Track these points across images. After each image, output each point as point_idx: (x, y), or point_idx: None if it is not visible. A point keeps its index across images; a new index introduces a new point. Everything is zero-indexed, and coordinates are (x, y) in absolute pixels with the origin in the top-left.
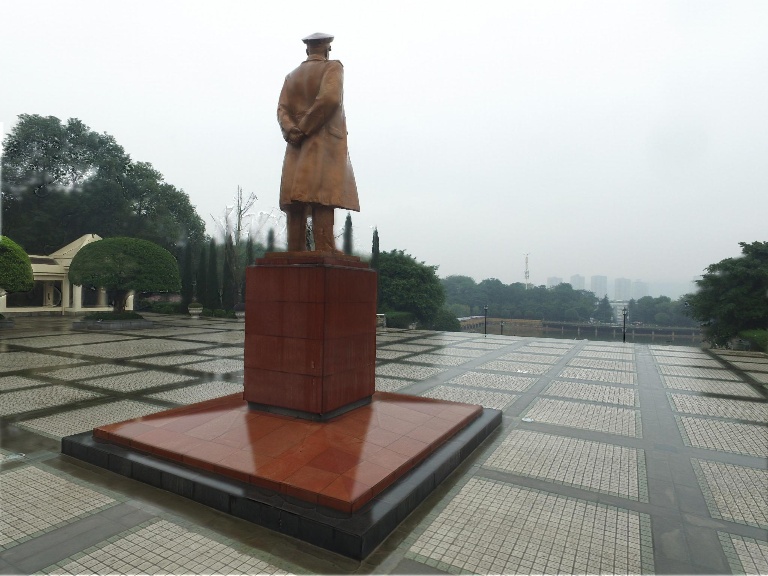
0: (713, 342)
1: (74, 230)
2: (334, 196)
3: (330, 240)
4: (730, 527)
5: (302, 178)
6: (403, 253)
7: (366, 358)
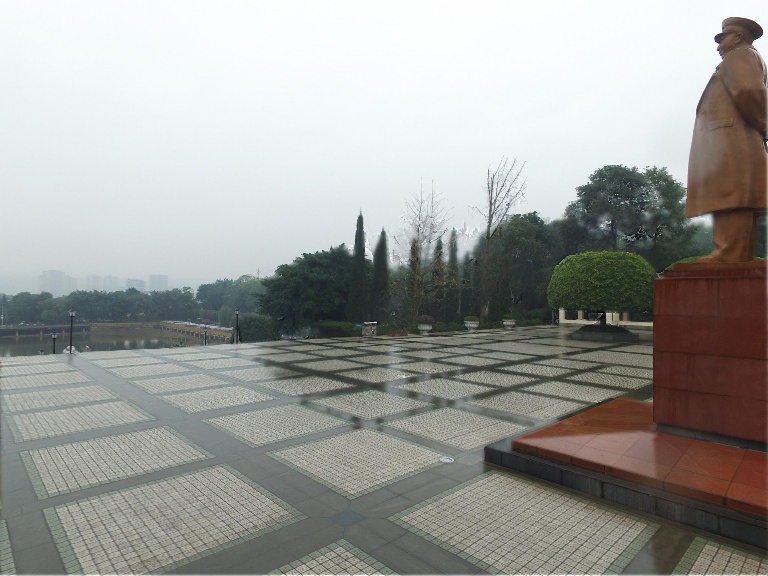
0: (279, 333)
1: None
2: None
3: None
4: None
5: None
6: None
7: None
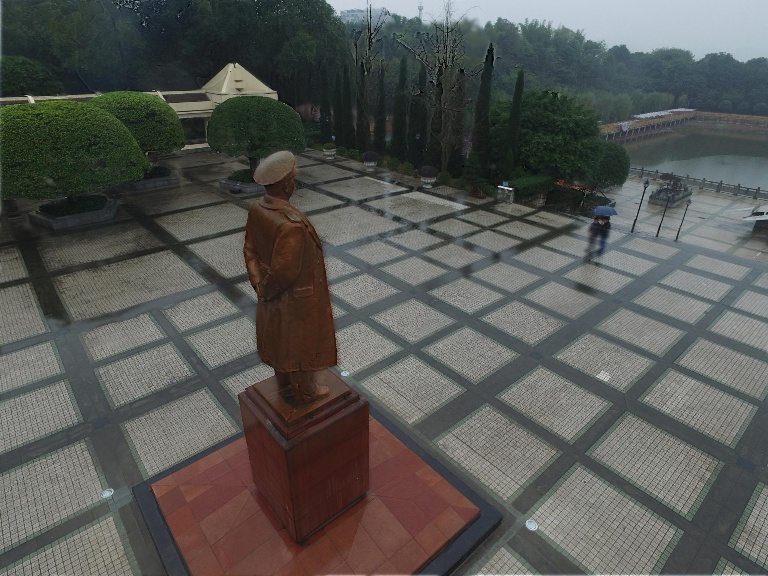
0: None
1: (218, 58)
2: (304, 362)
3: (308, 392)
4: None
5: (269, 344)
6: (557, 95)
7: (355, 475)
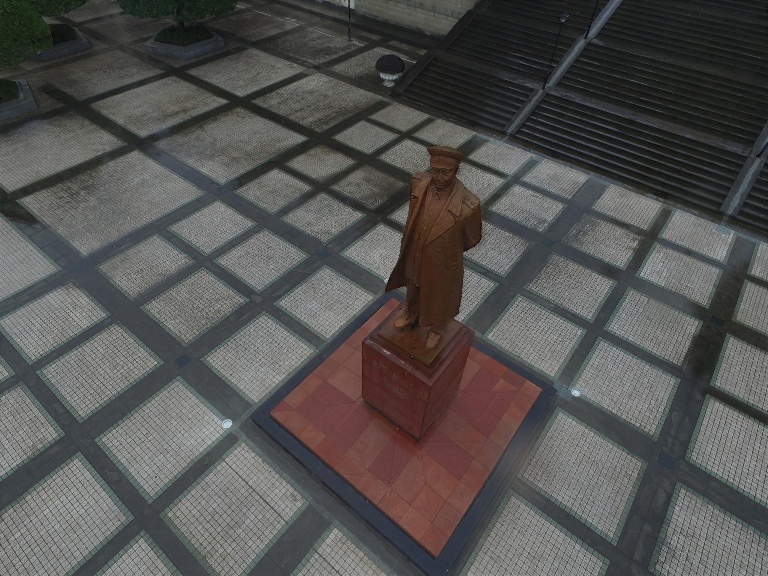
0: None
1: None
2: None
3: None
4: (251, 294)
5: None
6: None
7: None
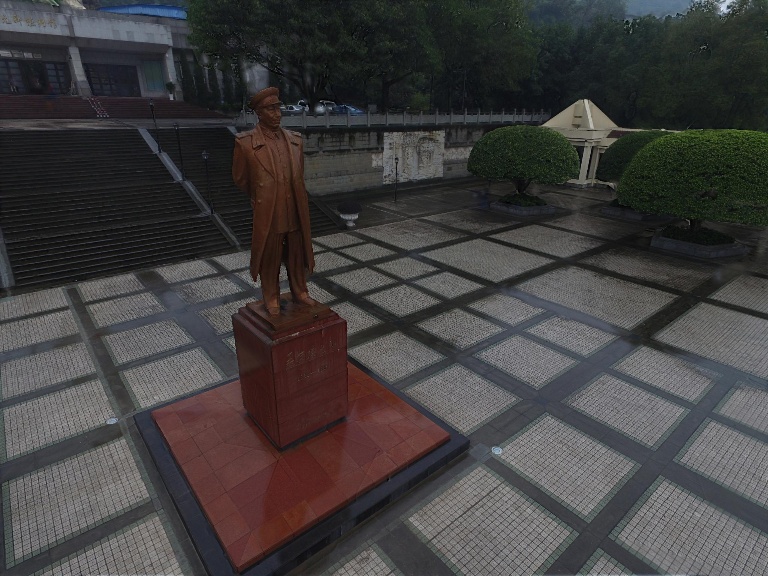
0: None
1: None
2: None
3: None
4: None
5: None
6: None
7: None
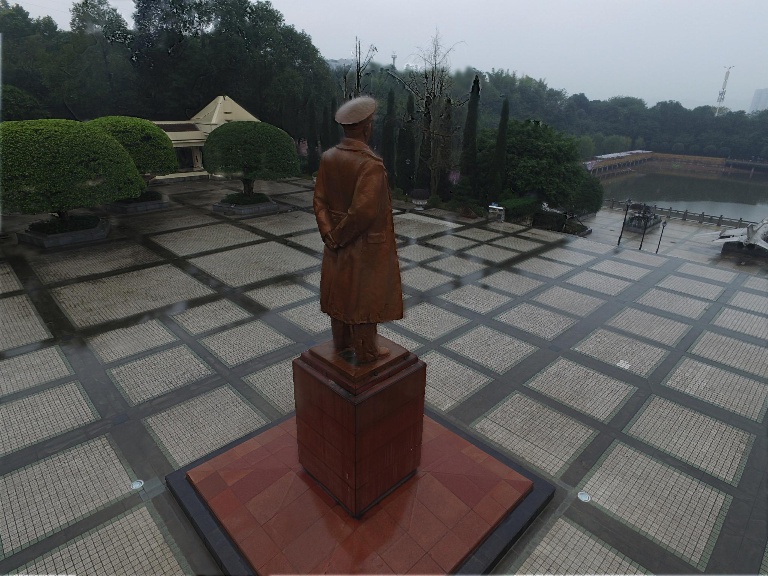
0: None
1: (208, 91)
2: (373, 313)
3: (371, 349)
4: None
5: (337, 295)
6: (539, 123)
7: (410, 445)
